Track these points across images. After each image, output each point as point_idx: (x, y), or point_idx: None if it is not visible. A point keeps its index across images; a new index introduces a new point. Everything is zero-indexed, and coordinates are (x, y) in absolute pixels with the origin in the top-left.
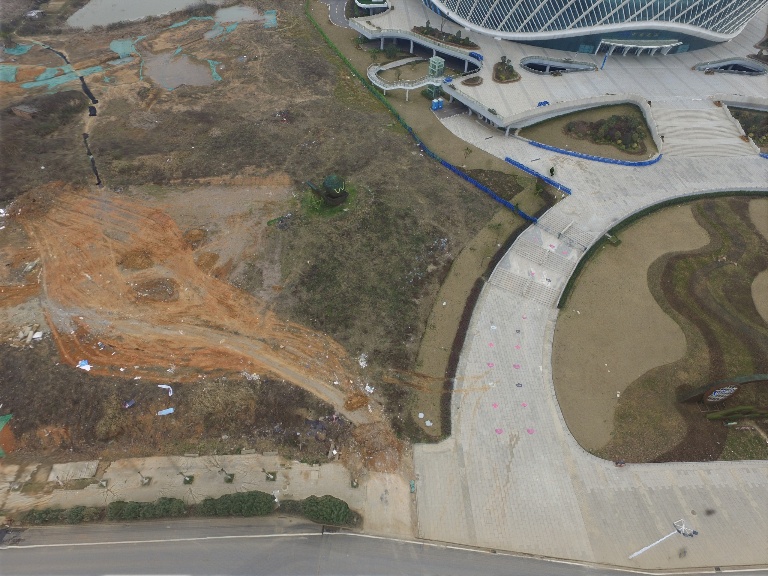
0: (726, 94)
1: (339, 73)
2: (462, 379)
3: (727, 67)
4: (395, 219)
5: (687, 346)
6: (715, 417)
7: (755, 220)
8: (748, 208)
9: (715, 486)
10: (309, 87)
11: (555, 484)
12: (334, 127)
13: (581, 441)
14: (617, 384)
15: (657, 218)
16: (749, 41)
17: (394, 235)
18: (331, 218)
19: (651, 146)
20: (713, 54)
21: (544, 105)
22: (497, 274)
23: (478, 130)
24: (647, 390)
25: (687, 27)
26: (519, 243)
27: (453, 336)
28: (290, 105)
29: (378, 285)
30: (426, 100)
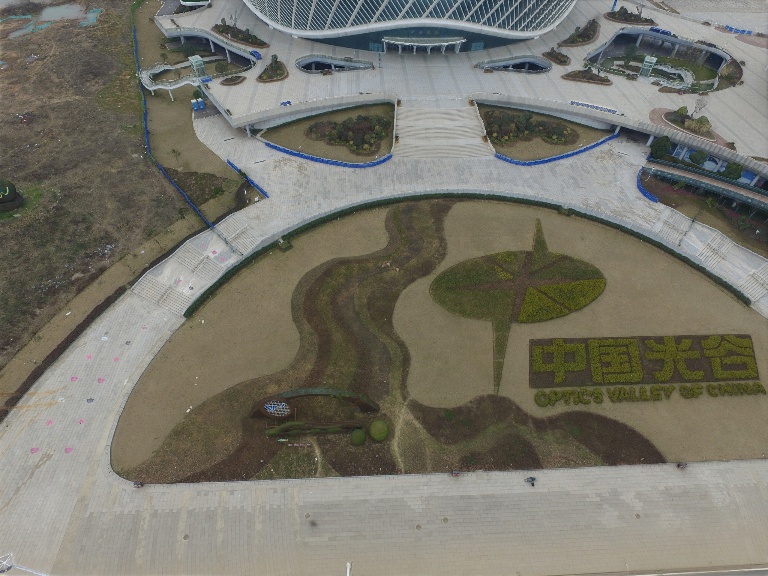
0: (486, 93)
1: (121, 73)
2: (33, 394)
3: (523, 65)
4: (67, 225)
5: (295, 357)
6: (272, 433)
7: (447, 223)
8: (448, 211)
9: (228, 508)
10: (75, 87)
11: (55, 507)
12: (70, 129)
13: (116, 460)
14: (195, 398)
15: (346, 222)
16: (557, 38)
17: (55, 241)
18: None
19: (386, 147)
20: (509, 52)
21: (285, 105)
22: (143, 282)
23: (224, 131)
24: (223, 404)
25: (464, 24)
26: (184, 249)
27: (53, 348)
28: (41, 106)
29: (2, 295)
30: None
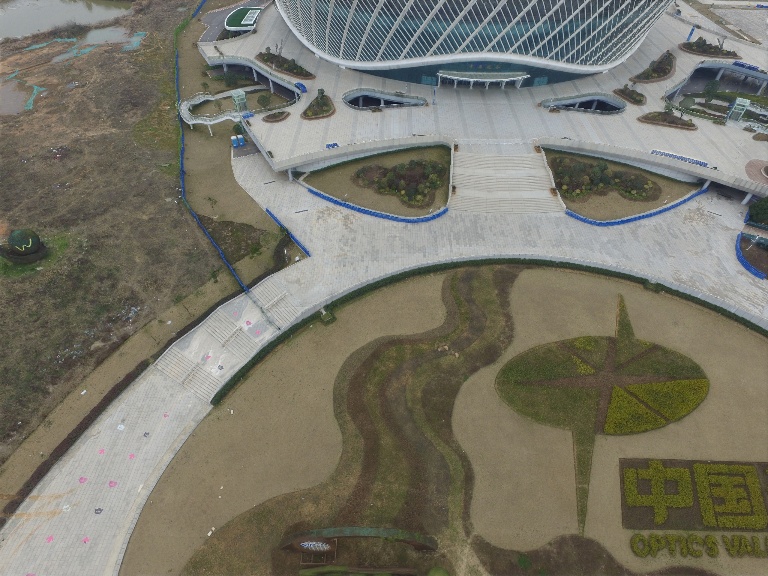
0: (554, 137)
1: (160, 103)
2: (35, 498)
3: (591, 102)
4: (91, 281)
5: (337, 466)
6: (307, 575)
7: (514, 297)
8: (514, 280)
9: None
10: (113, 119)
11: None
12: (104, 166)
13: None
14: (219, 516)
15: (397, 290)
16: (628, 73)
17: (77, 302)
18: (14, 279)
19: (441, 198)
20: (575, 88)
21: (331, 147)
22: (168, 356)
23: (264, 173)
24: (250, 528)
25: (529, 59)
26: (215, 317)
27: (64, 437)
28: (77, 139)
29: (15, 366)
30: (234, 135)
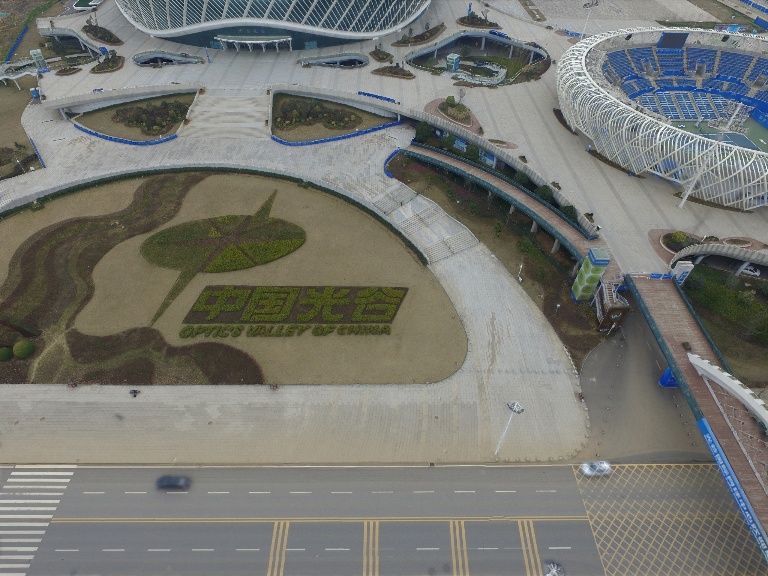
0: (287, 84)
1: None
2: None
3: (353, 62)
4: None
5: None
6: None
7: (191, 192)
8: (199, 182)
9: None
10: None
11: None
12: None
13: None
14: None
15: (102, 189)
16: (395, 39)
17: None
18: None
19: (177, 129)
20: (340, 50)
21: (96, 92)
22: None
23: (48, 115)
24: None
25: (285, 24)
26: None
27: None
28: None
29: None
30: None
